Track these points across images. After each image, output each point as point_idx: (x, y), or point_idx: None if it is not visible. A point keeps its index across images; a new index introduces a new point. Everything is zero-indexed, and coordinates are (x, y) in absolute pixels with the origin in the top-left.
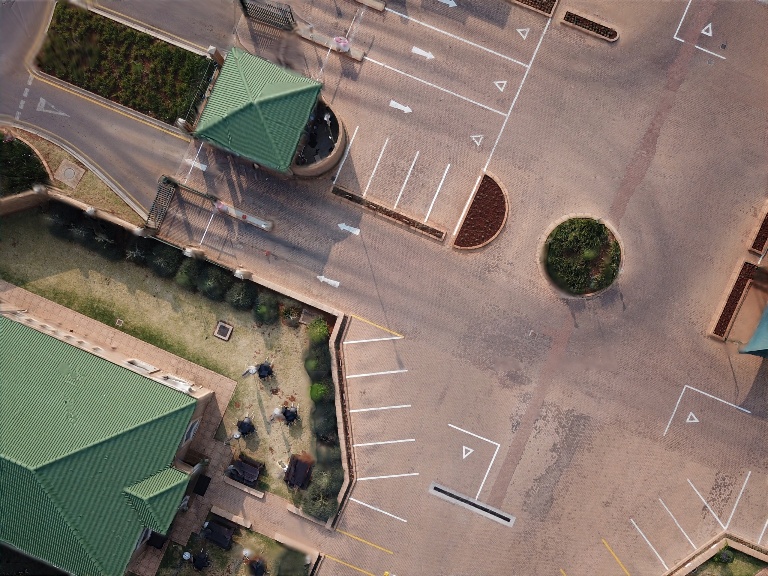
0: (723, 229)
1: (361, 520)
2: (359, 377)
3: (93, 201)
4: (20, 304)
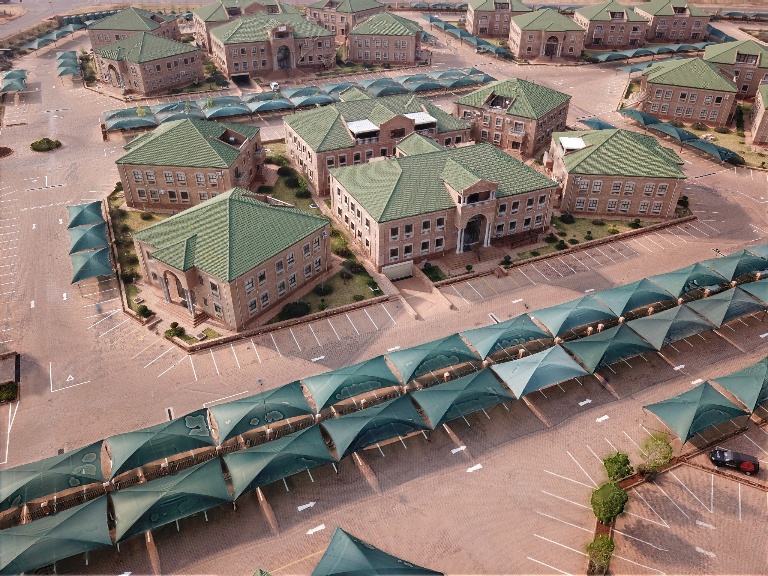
0: None
1: None
2: None
3: None
4: None
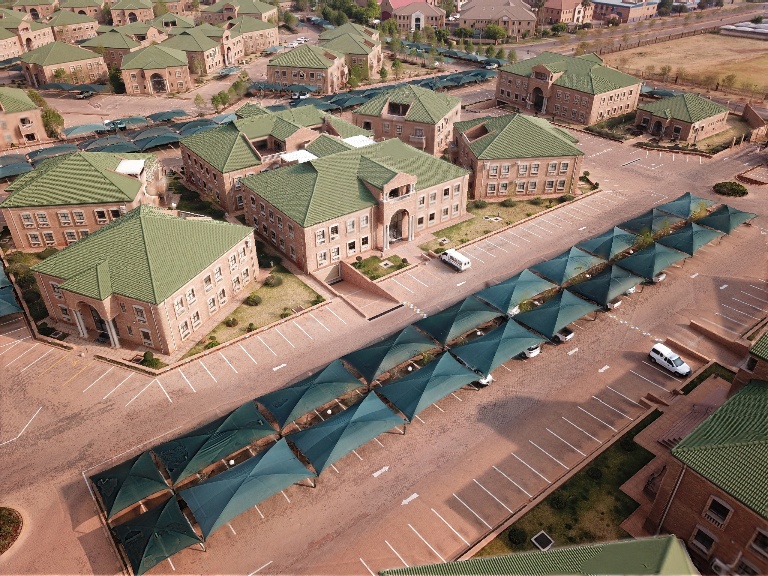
0: None
1: None
2: None
3: (760, 137)
4: (724, 127)
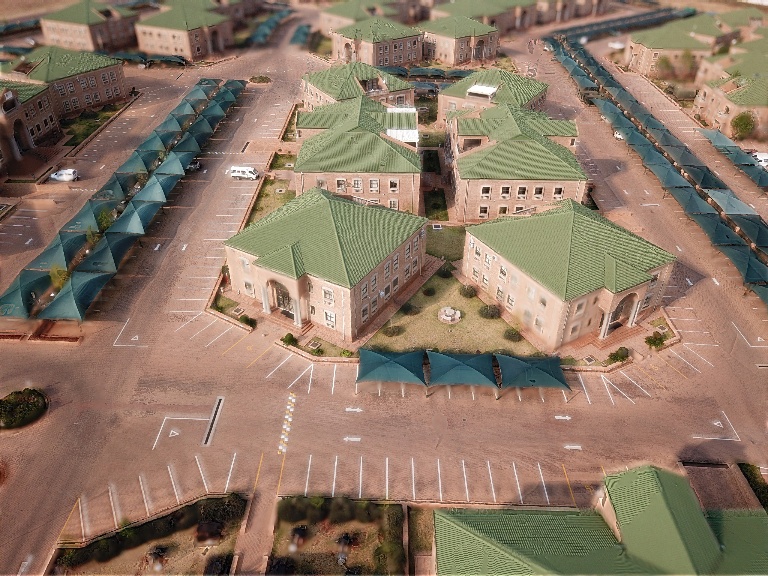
0: (4, 354)
1: (241, 480)
2: (116, 519)
3: None
4: None
